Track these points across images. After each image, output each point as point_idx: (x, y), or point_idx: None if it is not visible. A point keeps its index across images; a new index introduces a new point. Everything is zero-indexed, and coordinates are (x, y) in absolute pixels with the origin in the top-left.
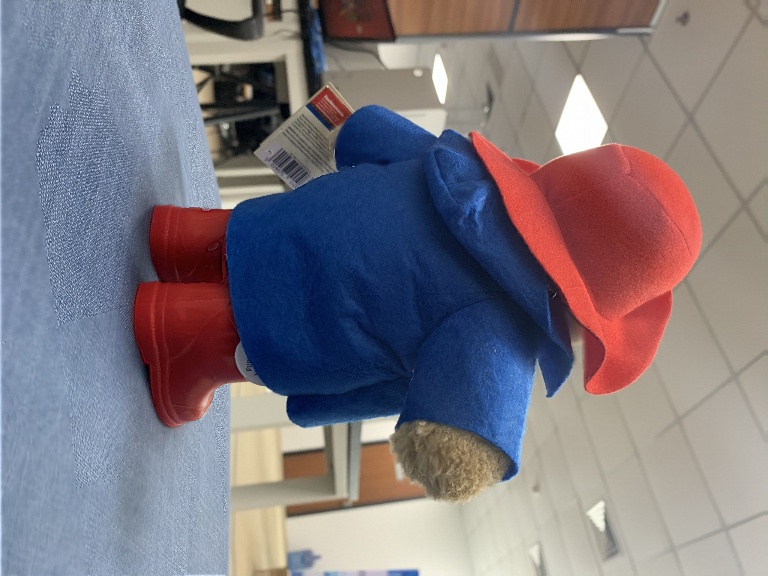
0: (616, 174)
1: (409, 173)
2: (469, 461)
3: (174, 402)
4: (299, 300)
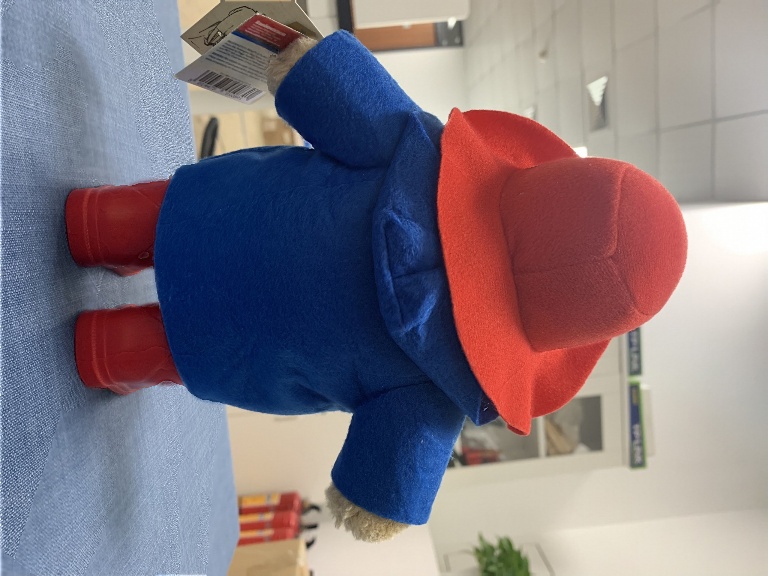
0: (596, 257)
1: (357, 220)
2: (384, 535)
3: (138, 388)
4: (239, 358)
